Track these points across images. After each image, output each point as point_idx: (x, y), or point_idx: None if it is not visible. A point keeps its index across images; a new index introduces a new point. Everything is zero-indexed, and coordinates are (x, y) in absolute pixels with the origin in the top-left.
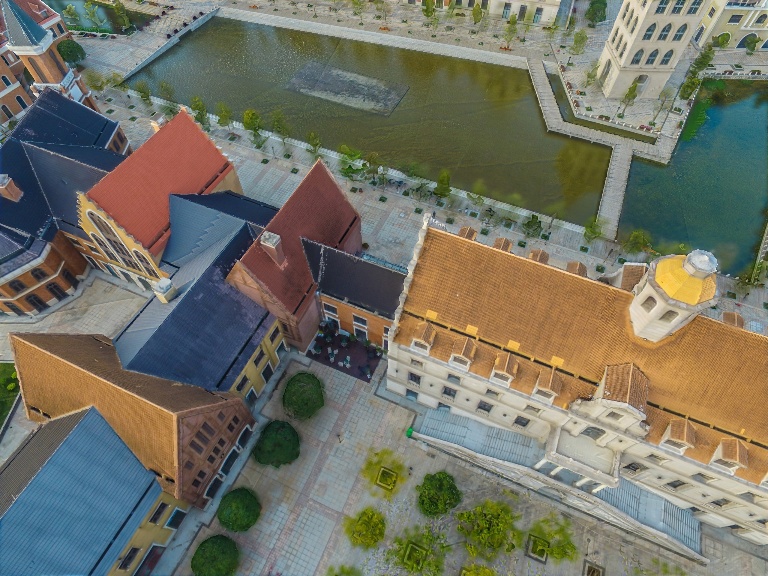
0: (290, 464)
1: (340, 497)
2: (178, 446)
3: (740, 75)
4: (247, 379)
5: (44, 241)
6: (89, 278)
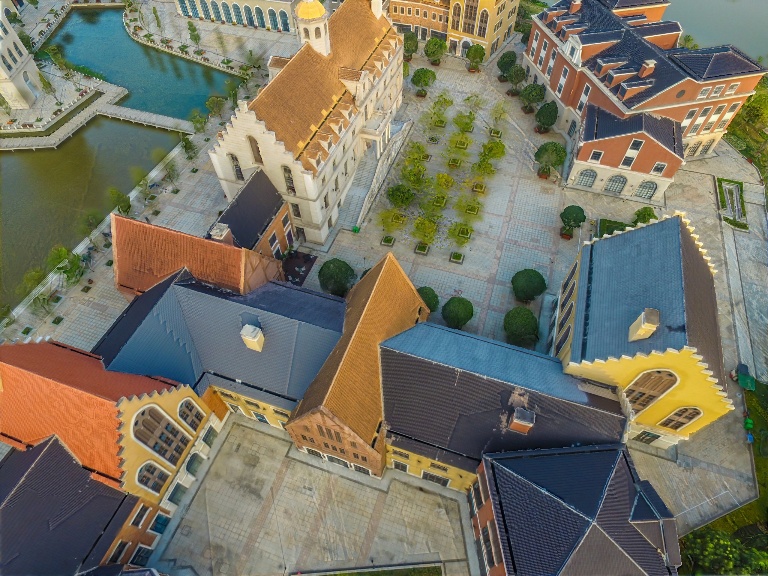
0: None
1: (403, 265)
2: (404, 274)
3: (40, 41)
4: None
5: (120, 575)
6: (161, 569)
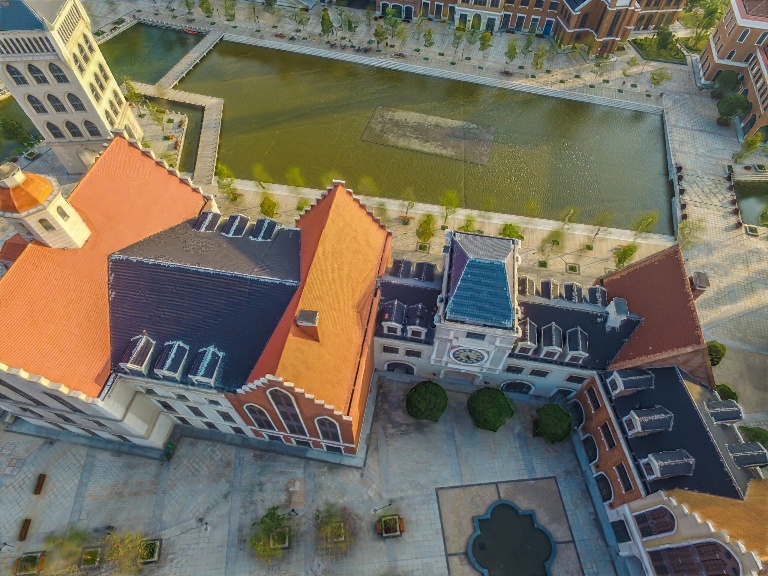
0: None
1: None
2: None
3: None
4: None
5: None
6: None
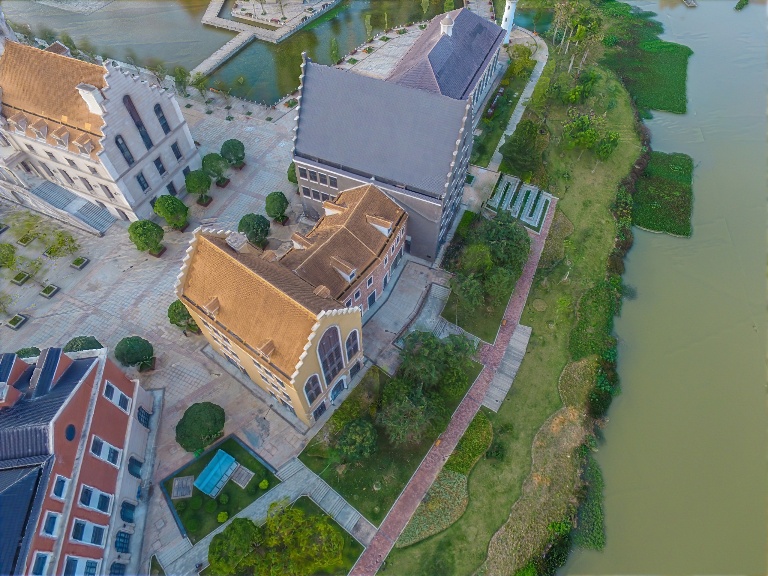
0: None
1: None
2: None
3: None
4: None
5: None
6: None
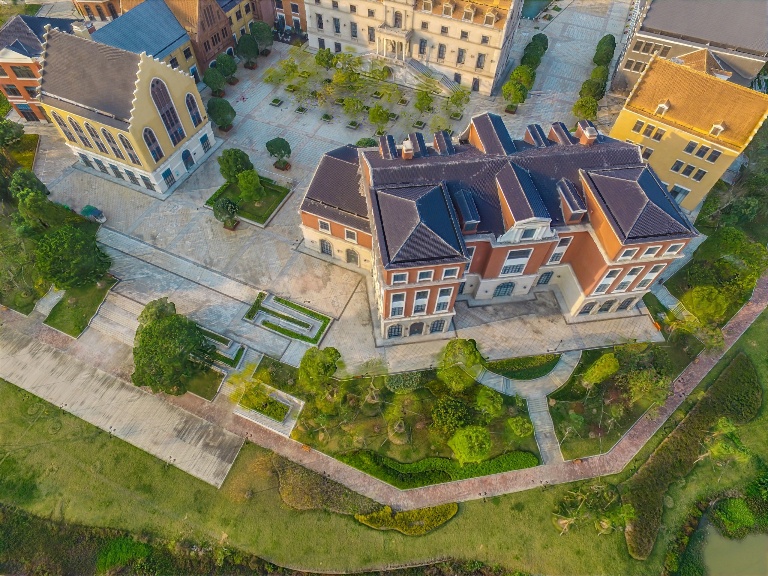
0: (254, 69)
1: None
2: None
3: None
4: (232, 23)
5: None
6: None
